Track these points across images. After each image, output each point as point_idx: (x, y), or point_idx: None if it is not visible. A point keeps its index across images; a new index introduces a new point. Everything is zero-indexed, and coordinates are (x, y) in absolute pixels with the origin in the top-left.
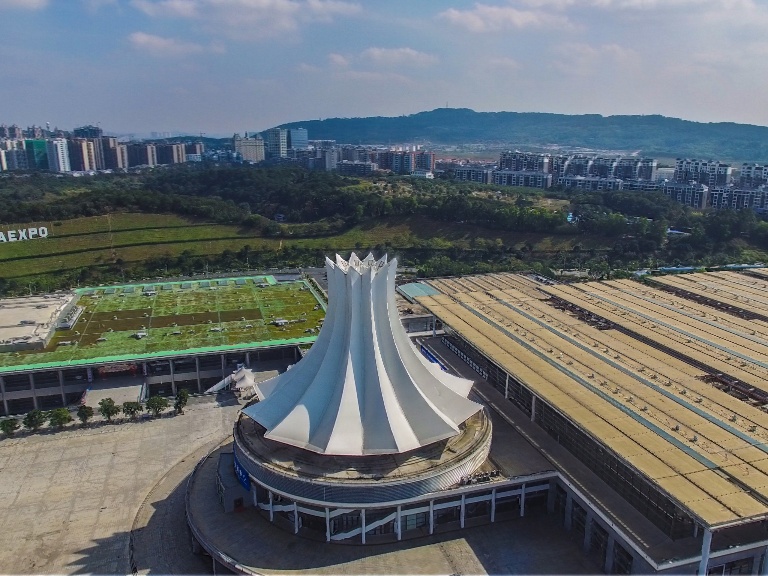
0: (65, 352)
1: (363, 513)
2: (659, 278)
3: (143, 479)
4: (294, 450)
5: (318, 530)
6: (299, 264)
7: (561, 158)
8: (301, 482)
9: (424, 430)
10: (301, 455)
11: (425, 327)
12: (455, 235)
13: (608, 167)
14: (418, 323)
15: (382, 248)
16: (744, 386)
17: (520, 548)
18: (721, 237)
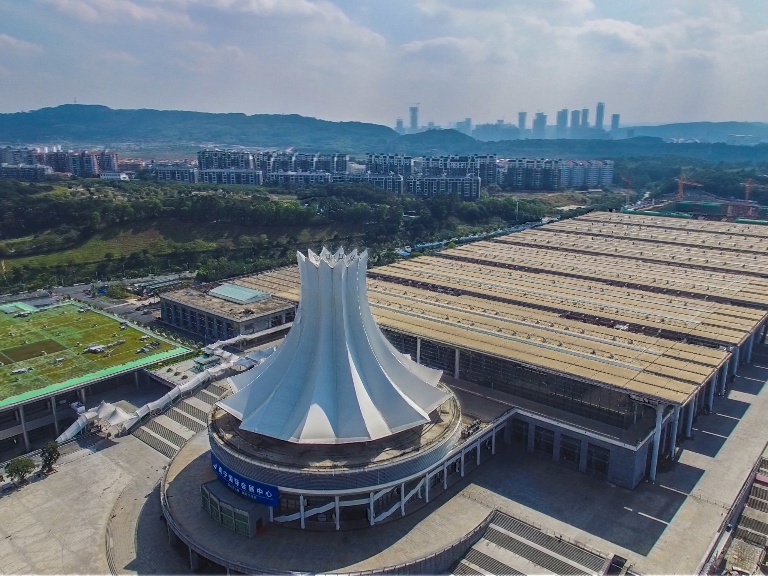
0: None
1: (403, 487)
2: (446, 252)
3: (82, 549)
4: (321, 449)
5: (355, 520)
6: (46, 285)
7: (266, 155)
8: (354, 474)
9: (423, 400)
10: (332, 452)
11: (267, 325)
12: (213, 235)
13: (310, 162)
14: (261, 322)
15: (140, 256)
16: (591, 317)
17: (516, 476)
18: (441, 217)
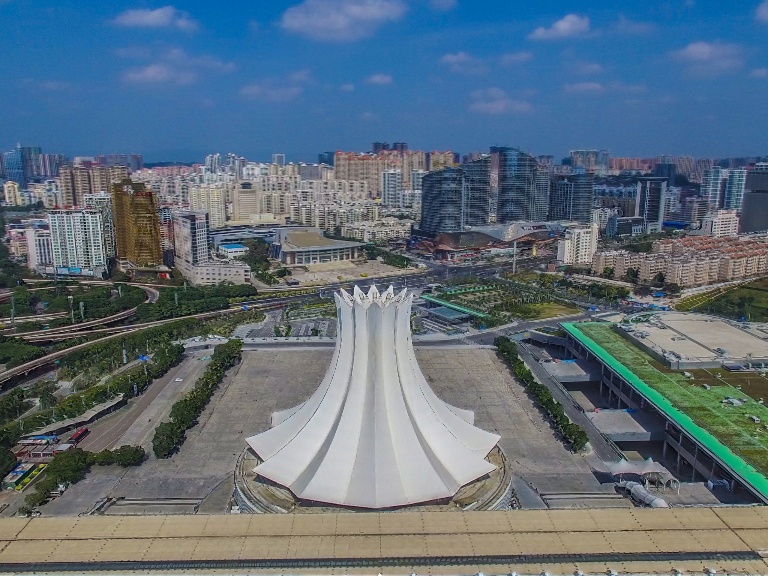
0: (663, 376)
1: None
2: None
3: None
4: None
5: None
6: None
7: None
8: None
9: None
10: None
11: None
12: None
13: None
14: None
15: None
16: None
17: None
18: None
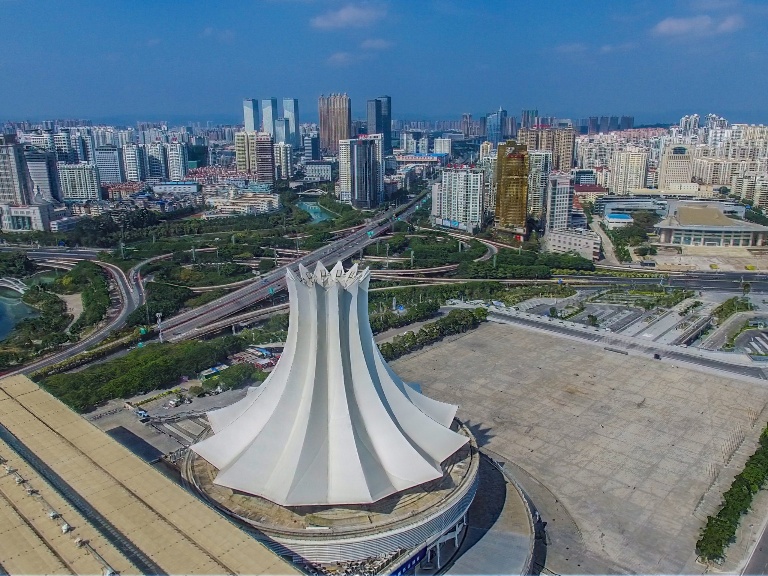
0: None
1: None
2: None
3: (555, 477)
4: None
5: None
6: None
7: None
8: None
9: None
10: None
11: None
12: None
13: None
14: None
15: None
16: None
17: None
18: None
